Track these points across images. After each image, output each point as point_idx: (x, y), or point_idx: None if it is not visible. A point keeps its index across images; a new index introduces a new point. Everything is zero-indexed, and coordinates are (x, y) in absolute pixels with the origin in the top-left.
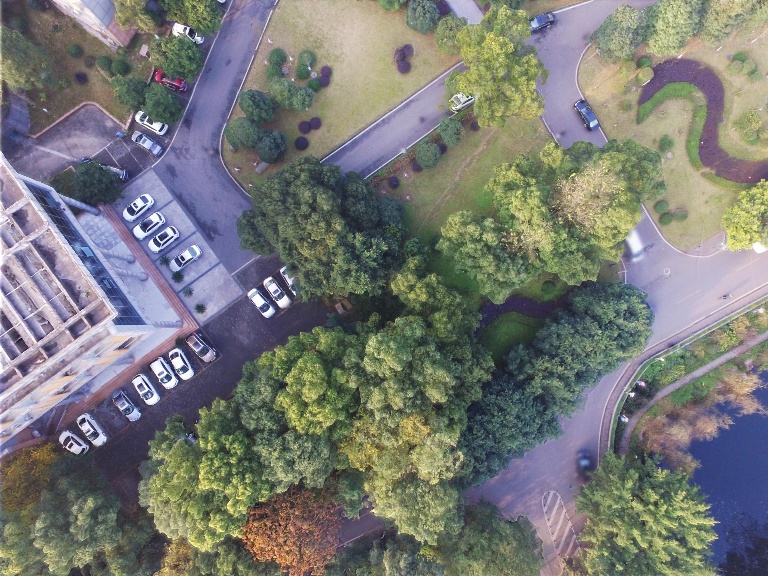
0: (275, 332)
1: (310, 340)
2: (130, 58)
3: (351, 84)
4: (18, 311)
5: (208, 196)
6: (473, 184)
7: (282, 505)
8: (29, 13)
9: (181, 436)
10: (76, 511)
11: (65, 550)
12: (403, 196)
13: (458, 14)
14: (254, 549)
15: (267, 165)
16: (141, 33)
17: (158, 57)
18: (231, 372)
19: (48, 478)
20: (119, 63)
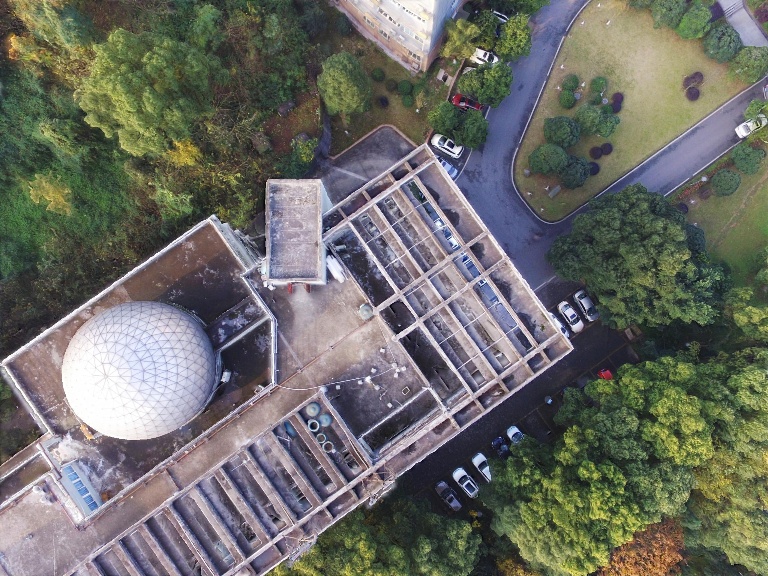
0: (567, 356)
1: (662, 370)
2: (428, 82)
3: (641, 111)
4: (476, 343)
5: (500, 219)
6: (758, 212)
7: (656, 536)
8: (332, 36)
9: (535, 462)
10: (455, 536)
11: (448, 575)
12: (690, 223)
13: (744, 42)
14: None
15: (559, 190)
16: (459, 59)
17: (474, 83)
18: (524, 395)
19: (382, 499)
20: (421, 87)
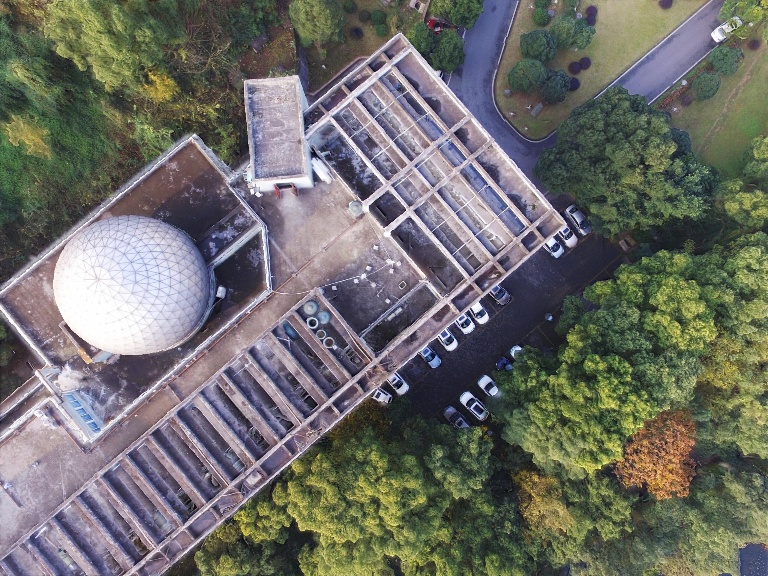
0: (564, 272)
1: (658, 263)
2: (401, 10)
3: (616, 23)
4: None
5: None
6: (740, 114)
7: (667, 423)
8: None
9: (540, 366)
10: (465, 441)
11: (462, 479)
12: None
13: None
14: (634, 470)
15: (541, 108)
16: None
17: (447, 3)
18: (524, 314)
19: (391, 421)
20: None
